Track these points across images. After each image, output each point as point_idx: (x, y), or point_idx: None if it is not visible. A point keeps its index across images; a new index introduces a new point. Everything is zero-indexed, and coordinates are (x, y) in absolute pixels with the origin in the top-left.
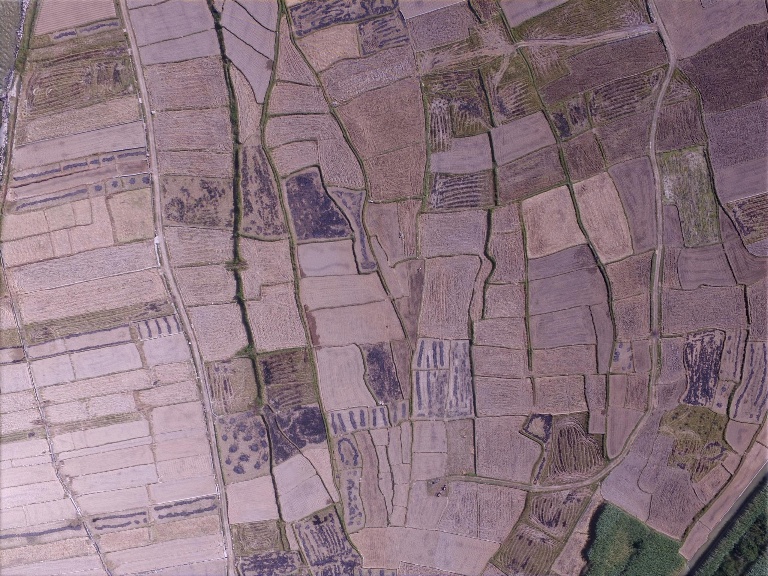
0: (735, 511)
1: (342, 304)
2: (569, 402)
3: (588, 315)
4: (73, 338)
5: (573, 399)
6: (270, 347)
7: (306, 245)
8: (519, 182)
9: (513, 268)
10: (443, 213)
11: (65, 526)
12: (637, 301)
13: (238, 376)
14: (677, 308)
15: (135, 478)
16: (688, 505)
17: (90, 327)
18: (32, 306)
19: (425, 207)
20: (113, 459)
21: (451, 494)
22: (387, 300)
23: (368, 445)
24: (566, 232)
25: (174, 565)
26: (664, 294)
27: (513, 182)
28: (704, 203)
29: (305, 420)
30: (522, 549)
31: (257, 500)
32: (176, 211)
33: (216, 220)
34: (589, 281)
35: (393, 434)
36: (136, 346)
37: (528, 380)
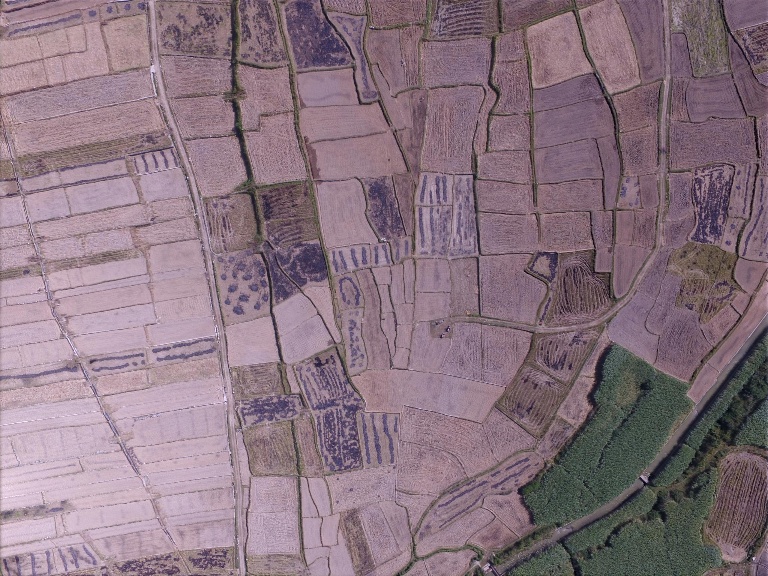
0: (744, 353)
1: (343, 136)
2: (575, 240)
3: (594, 148)
4: (68, 171)
5: (579, 236)
6: (269, 180)
7: (306, 74)
8: (524, 8)
9: (518, 98)
10: (446, 41)
11: (62, 368)
12: (644, 134)
13: (237, 213)
14: (685, 141)
15: (133, 318)
16: (696, 347)
17: (85, 160)
18: (26, 137)
19: (428, 34)
20: (110, 298)
21: (455, 336)
22: (389, 132)
23: (370, 285)
24: (572, 61)
25: (173, 409)
26: (672, 127)
27: (518, 8)
28: (713, 31)
29: (306, 257)
30: (527, 393)
31: (257, 342)
32: (172, 39)
33: (213, 49)
34: (595, 113)
35: (395, 272)
36: (132, 180)
37: (533, 216)
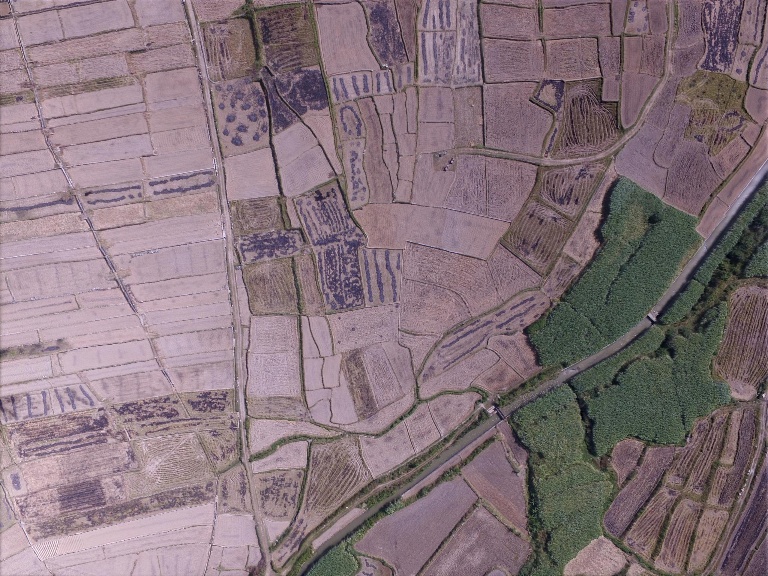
0: (754, 187)
1: None
2: (582, 67)
3: None
4: None
5: (586, 64)
6: (268, 2)
7: None
8: None
9: None
10: None
11: (56, 200)
12: None
13: (235, 39)
14: None
15: (129, 149)
16: (705, 181)
17: None
18: None
19: None
20: (105, 128)
21: (459, 169)
22: None
23: (372, 114)
24: None
25: (171, 245)
26: None
27: None
28: None
29: (306, 84)
30: (533, 229)
31: (256, 175)
32: None
33: None
34: None
35: (398, 101)
36: (127, 2)
37: (539, 42)
